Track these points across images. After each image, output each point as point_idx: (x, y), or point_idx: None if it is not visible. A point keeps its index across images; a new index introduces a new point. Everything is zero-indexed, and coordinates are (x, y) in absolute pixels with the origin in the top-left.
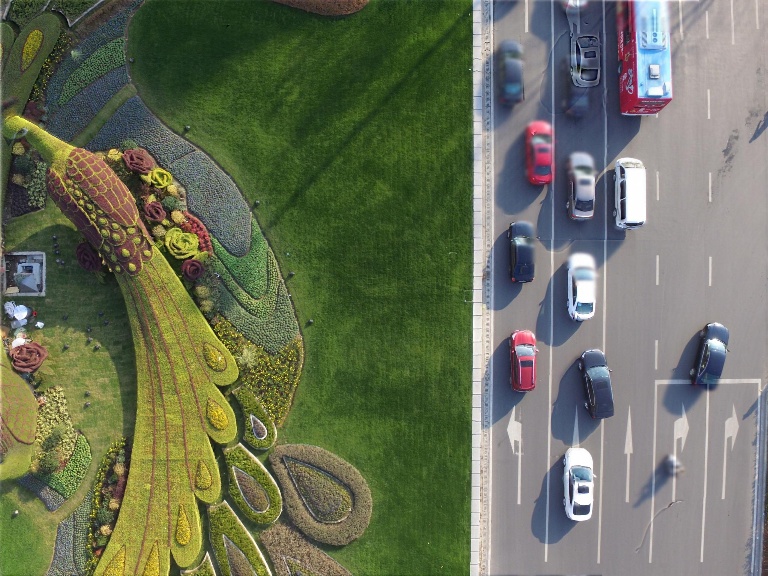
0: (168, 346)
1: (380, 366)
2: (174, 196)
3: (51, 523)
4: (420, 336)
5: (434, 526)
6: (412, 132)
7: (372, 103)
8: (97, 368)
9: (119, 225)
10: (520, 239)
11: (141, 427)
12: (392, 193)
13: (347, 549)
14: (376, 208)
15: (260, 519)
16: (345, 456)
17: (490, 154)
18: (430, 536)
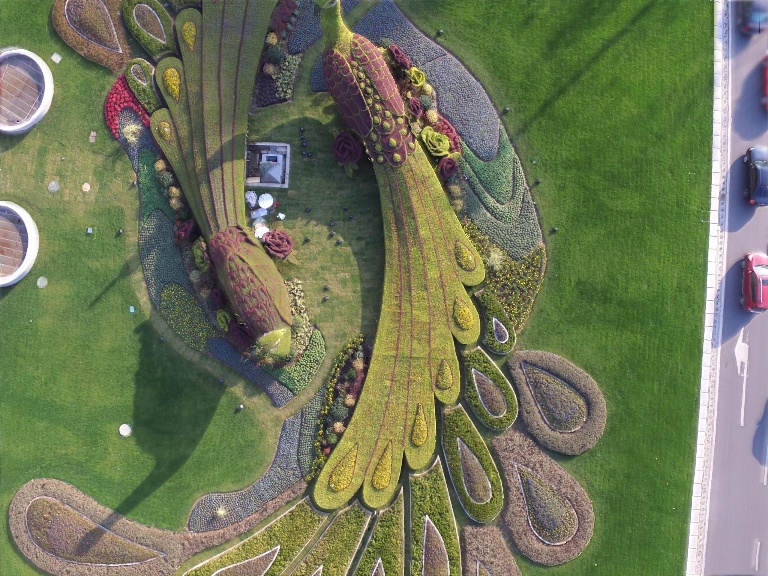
0: (422, 241)
1: (620, 278)
2: (429, 96)
3: (276, 419)
4: (659, 252)
5: (662, 442)
6: (657, 54)
7: (620, 23)
8: (338, 263)
9: (391, 113)
10: (760, 163)
11: (386, 322)
12: (637, 111)
13: (577, 460)
14: (621, 124)
15: (496, 424)
16: (581, 366)
17: (727, 82)
18: (658, 452)
